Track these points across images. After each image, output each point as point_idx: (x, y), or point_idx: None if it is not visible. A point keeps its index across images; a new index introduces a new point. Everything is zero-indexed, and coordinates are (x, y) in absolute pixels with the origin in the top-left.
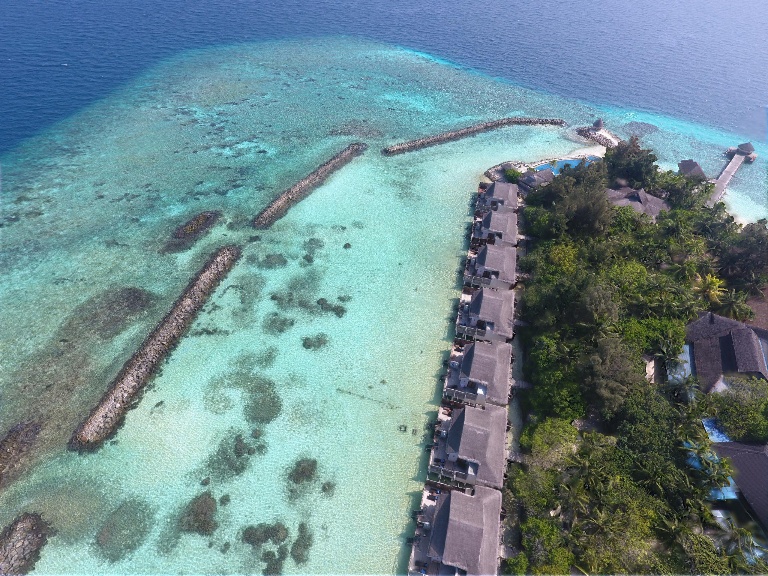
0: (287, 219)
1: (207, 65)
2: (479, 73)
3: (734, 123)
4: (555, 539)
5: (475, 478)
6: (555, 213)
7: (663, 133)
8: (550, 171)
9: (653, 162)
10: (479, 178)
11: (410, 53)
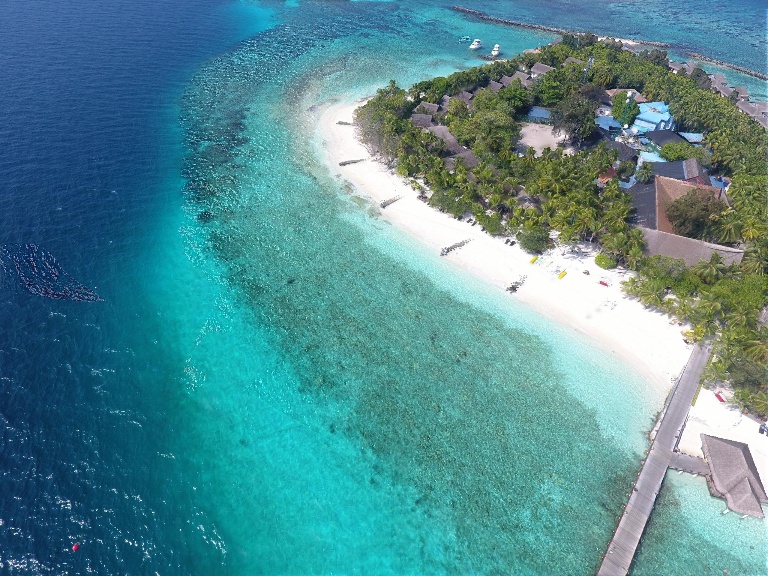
0: None
1: None
2: None
3: None
4: (767, 133)
5: None
6: None
7: None
8: None
9: None
10: None
11: None
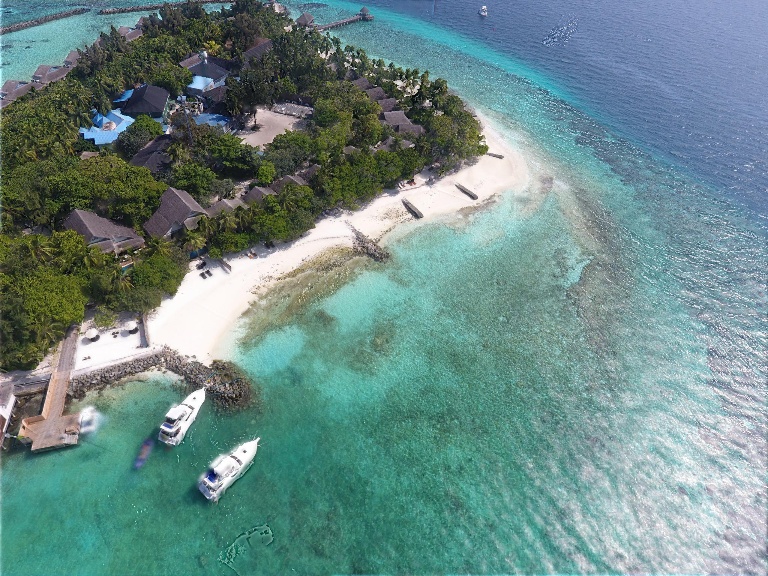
0: None
1: None
2: None
3: None
4: None
5: (4, 98)
6: None
7: (327, 8)
8: None
9: None
10: None
11: None
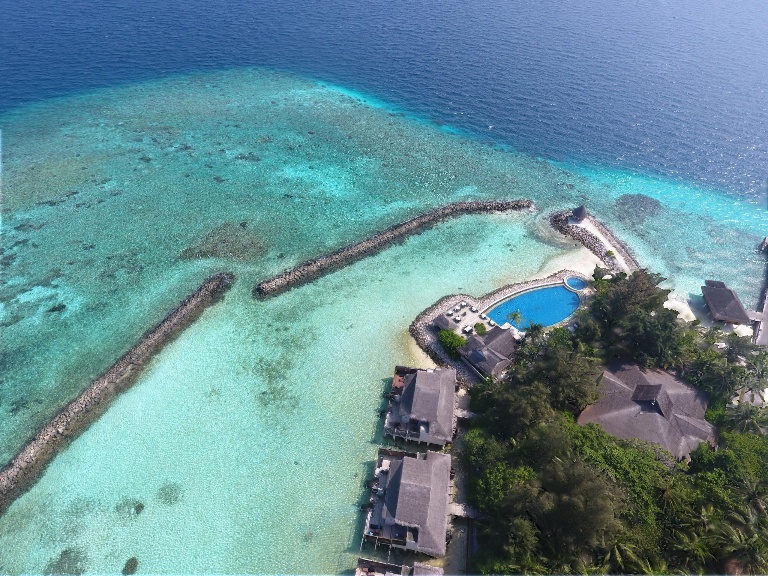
0: (38, 492)
1: (41, 131)
2: (421, 119)
3: (760, 188)
4: None
5: None
6: (513, 504)
7: (669, 213)
8: (509, 335)
9: (662, 276)
10: (400, 340)
11: (333, 92)
